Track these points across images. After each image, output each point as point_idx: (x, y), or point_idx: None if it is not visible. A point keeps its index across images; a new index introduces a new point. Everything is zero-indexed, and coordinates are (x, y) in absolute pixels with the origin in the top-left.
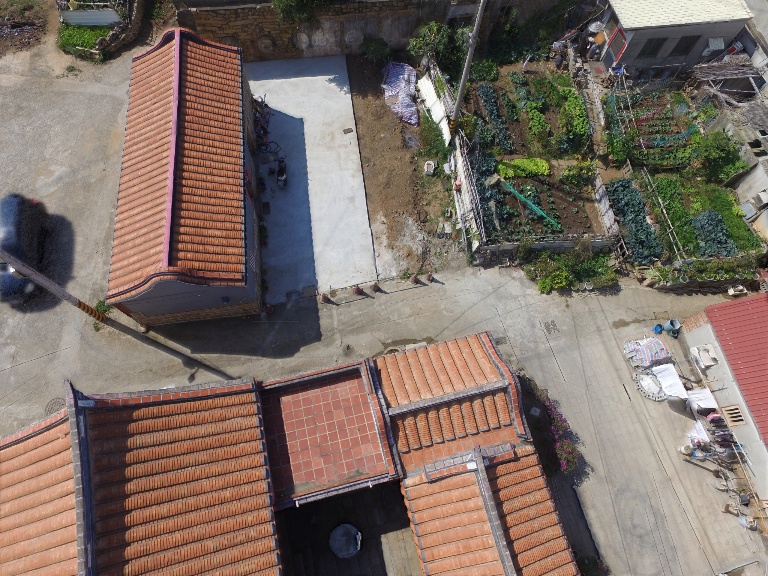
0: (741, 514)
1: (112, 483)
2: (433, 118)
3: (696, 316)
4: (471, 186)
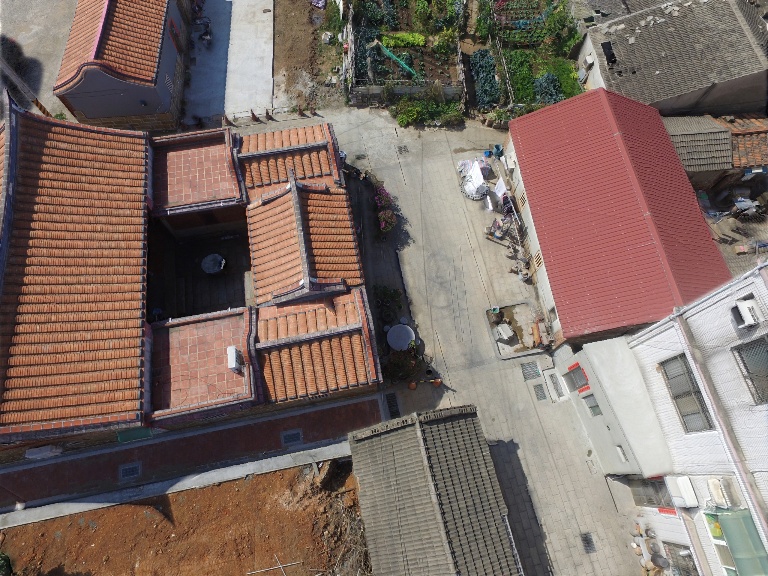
0: None
1: (32, 161)
2: (337, 3)
3: (508, 134)
4: (352, 45)
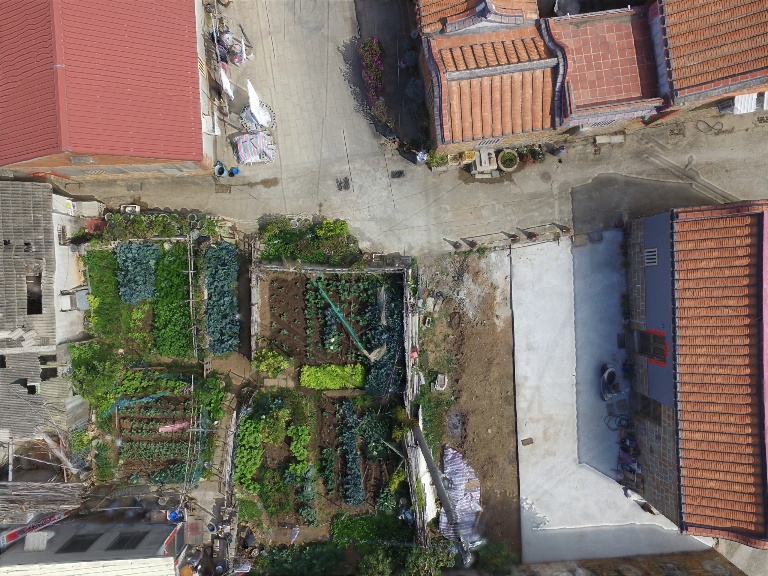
0: None
1: None
2: None
3: None
4: None
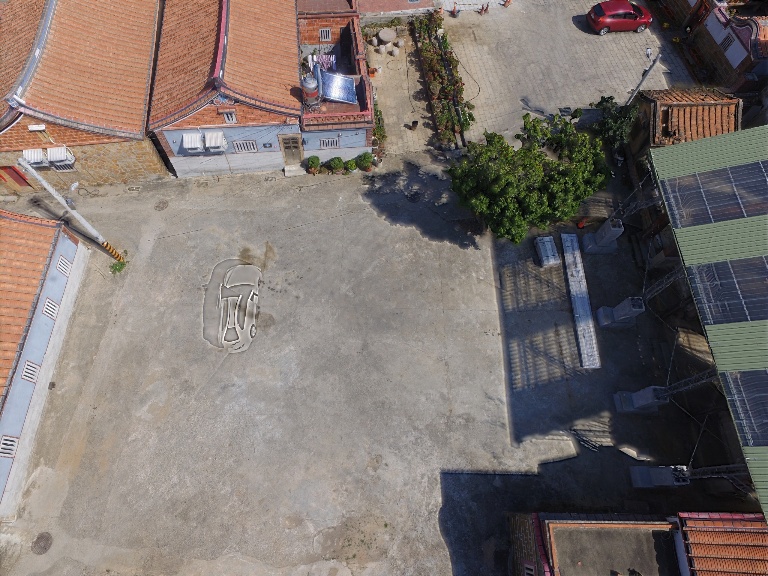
0: None
1: None
2: None
3: None
4: None
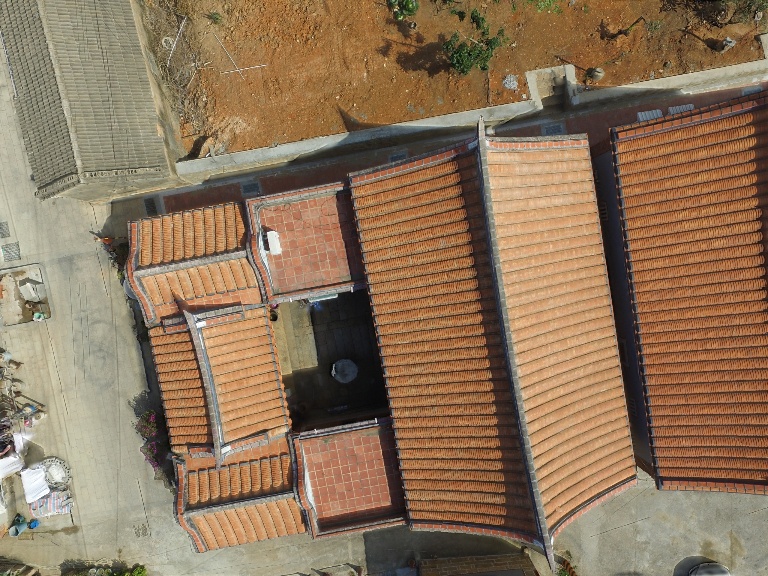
0: (7, 363)
1: (513, 472)
2: None
3: None
4: None
